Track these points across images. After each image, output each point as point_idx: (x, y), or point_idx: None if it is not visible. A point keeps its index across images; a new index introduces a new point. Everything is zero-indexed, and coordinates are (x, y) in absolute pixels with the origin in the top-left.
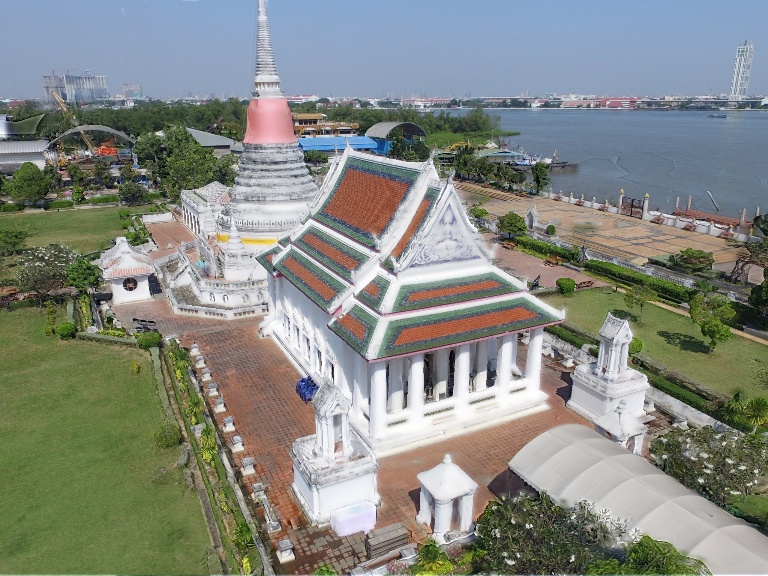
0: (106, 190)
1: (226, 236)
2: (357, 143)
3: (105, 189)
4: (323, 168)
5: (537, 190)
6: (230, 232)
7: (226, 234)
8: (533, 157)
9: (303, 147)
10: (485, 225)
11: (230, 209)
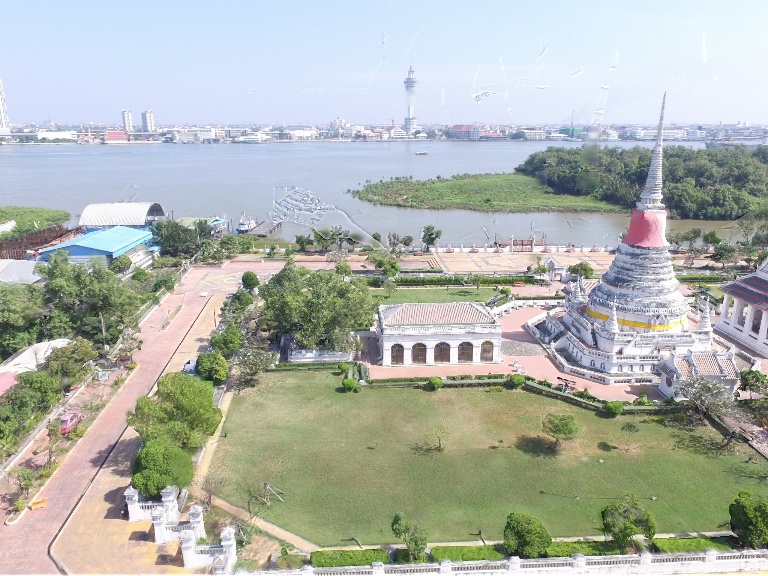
0: (70, 397)
1: (673, 323)
2: (141, 236)
3: (69, 396)
4: (176, 274)
5: (428, 248)
6: (708, 314)
7: (672, 322)
8: (249, 221)
9: (113, 254)
10: (537, 277)
11: (667, 301)
